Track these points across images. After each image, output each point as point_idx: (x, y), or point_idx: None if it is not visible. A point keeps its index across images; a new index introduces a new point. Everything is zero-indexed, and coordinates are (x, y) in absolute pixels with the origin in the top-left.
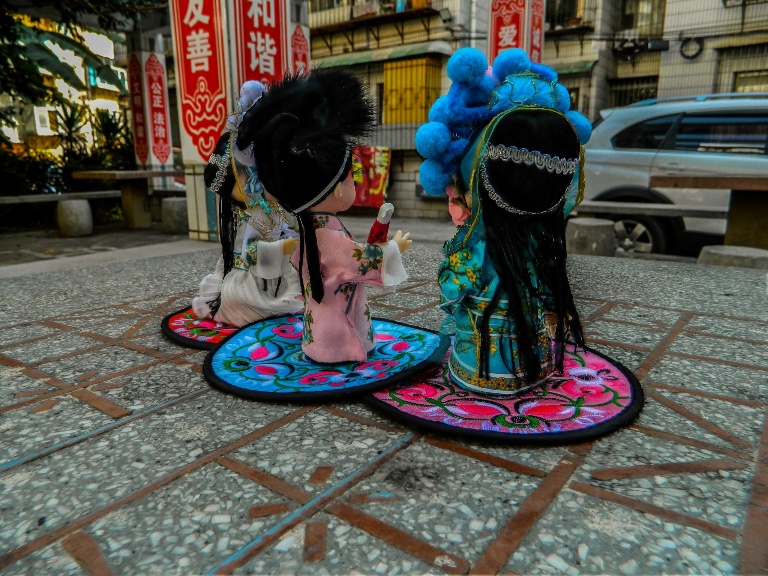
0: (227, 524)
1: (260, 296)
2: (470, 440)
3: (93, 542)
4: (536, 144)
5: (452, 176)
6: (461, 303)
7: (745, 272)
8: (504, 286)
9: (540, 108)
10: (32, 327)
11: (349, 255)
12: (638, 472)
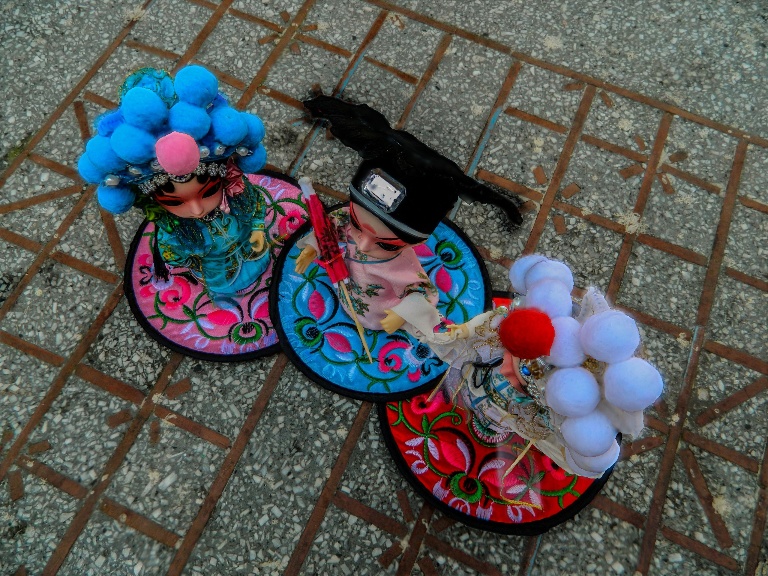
0: (358, 96)
1: None
2: None
3: (405, 80)
4: None
5: None
6: None
7: None
8: None
9: None
10: (759, 346)
11: None
12: None
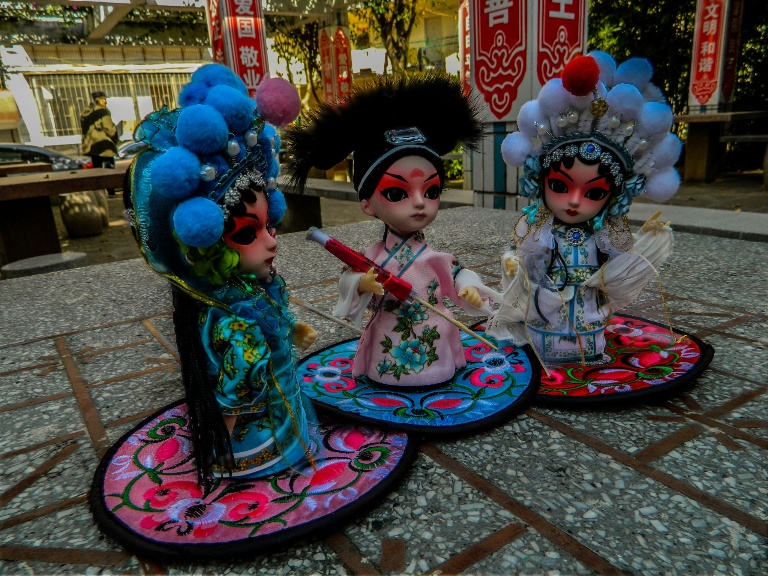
0: None
1: None
2: None
3: None
4: None
5: None
6: None
7: None
8: None
9: None
10: None
11: None
12: (49, 463)
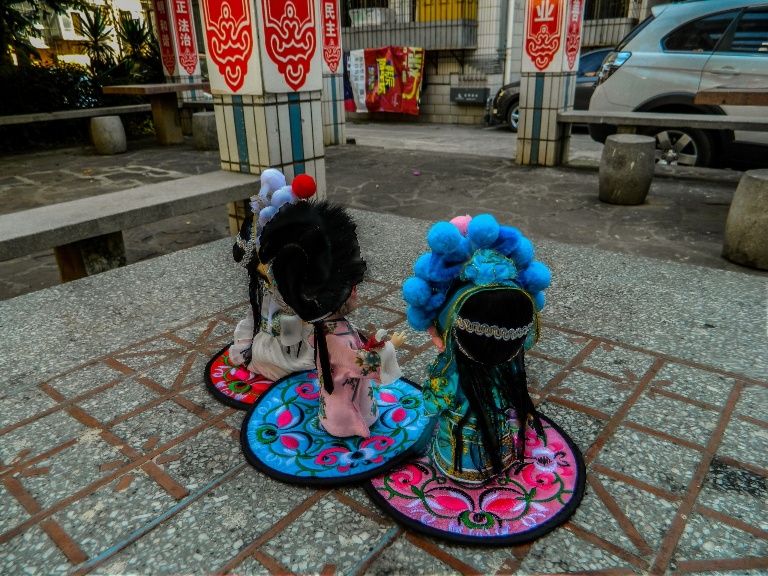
0: None
1: (284, 359)
2: (439, 539)
3: None
4: (495, 319)
5: (433, 320)
6: (441, 413)
7: (738, 284)
8: (473, 410)
9: (500, 288)
10: (99, 368)
11: (353, 362)
12: None
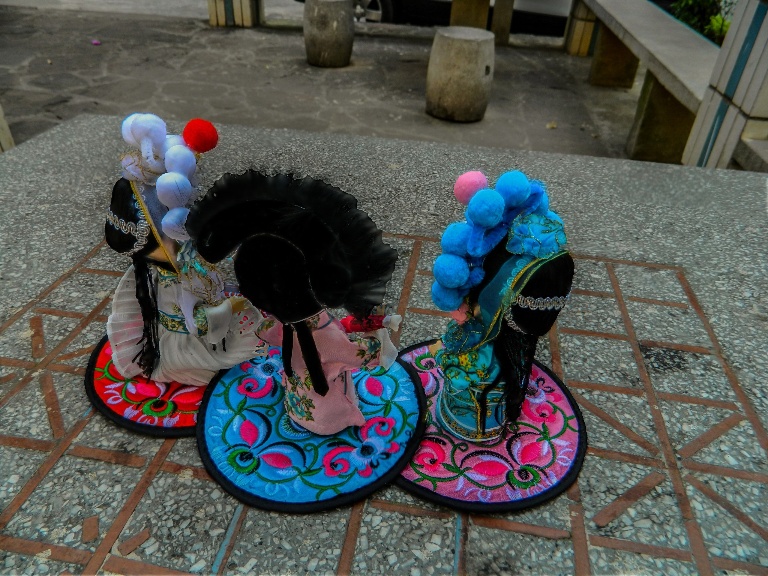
0: None
1: (214, 359)
2: (506, 512)
3: None
4: (555, 290)
5: (465, 297)
6: None
7: (546, 164)
8: (505, 376)
9: (557, 256)
10: None
11: (353, 355)
12: (618, 509)
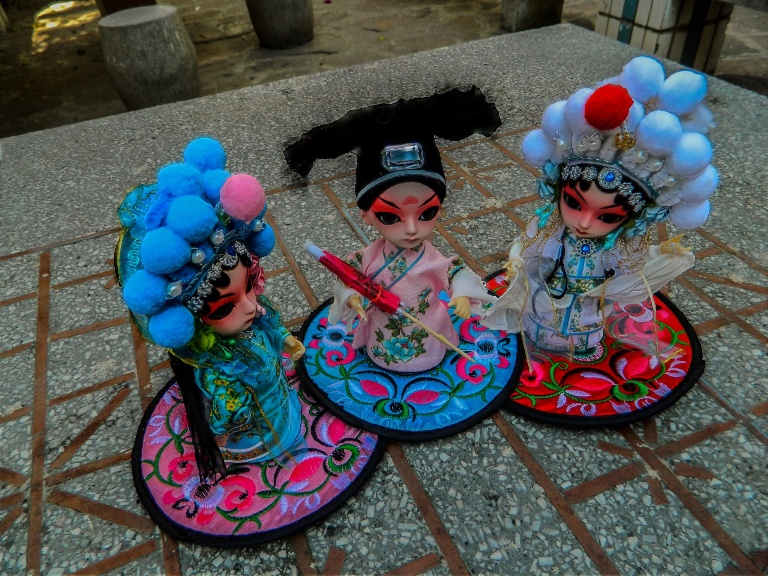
0: None
1: None
2: None
3: None
4: None
5: None
6: None
7: None
8: None
9: None
10: None
11: None
12: (107, 409)
